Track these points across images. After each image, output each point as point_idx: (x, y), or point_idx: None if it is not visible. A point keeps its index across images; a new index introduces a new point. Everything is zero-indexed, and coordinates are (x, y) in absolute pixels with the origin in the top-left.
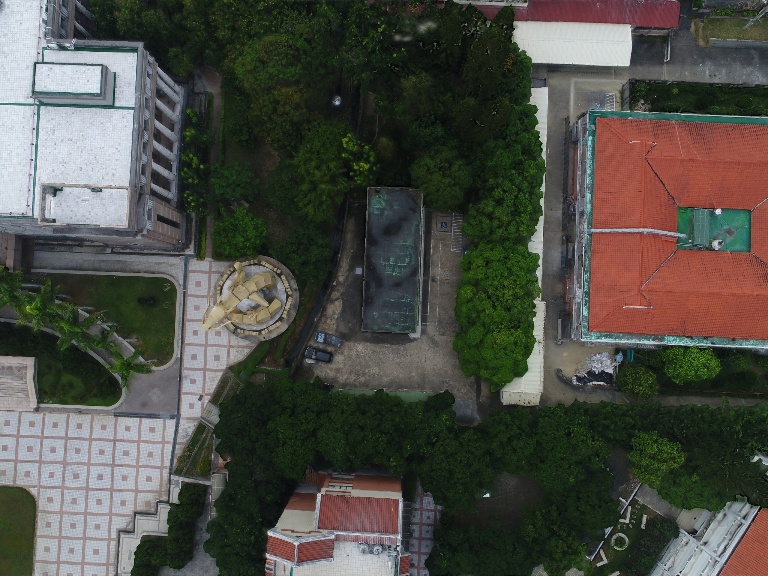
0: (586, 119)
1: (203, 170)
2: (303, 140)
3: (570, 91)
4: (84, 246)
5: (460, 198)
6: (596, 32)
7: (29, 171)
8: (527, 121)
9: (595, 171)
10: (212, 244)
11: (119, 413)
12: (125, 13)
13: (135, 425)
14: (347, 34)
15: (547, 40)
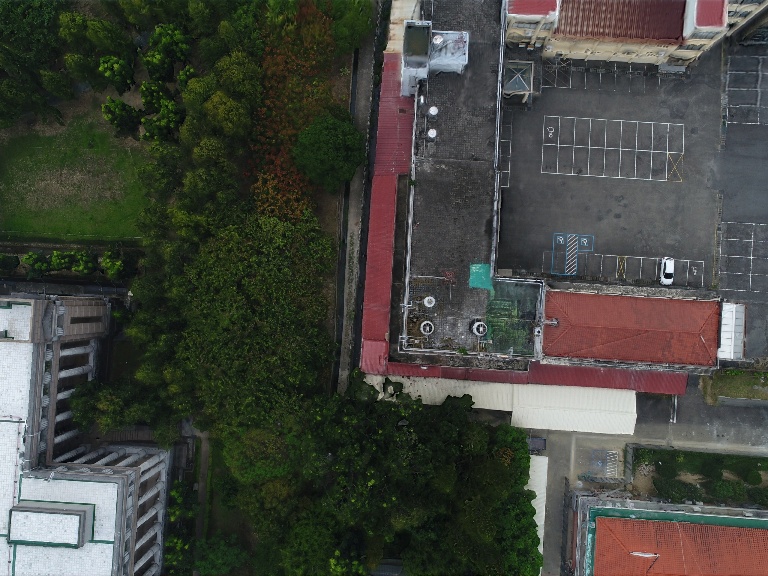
0: (586, 510)
1: None
2: (291, 530)
3: (571, 448)
4: None
5: None
6: (599, 399)
7: None
8: (524, 521)
9: (594, 574)
10: None
11: None
12: (107, 421)
13: None
14: (335, 484)
15: (548, 409)
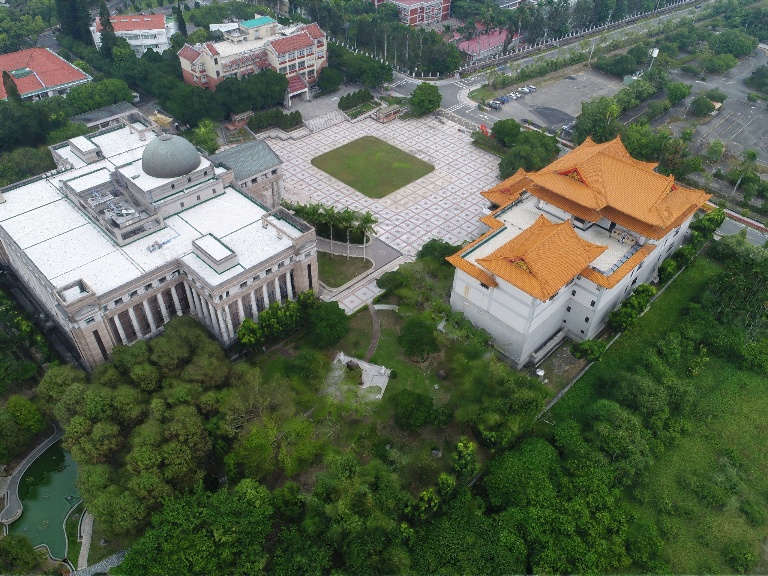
0: None
1: None
2: None
3: None
4: None
5: None
6: None
7: (141, 148)
8: None
9: None
10: None
11: None
12: None
13: None
14: (0, 110)
15: None
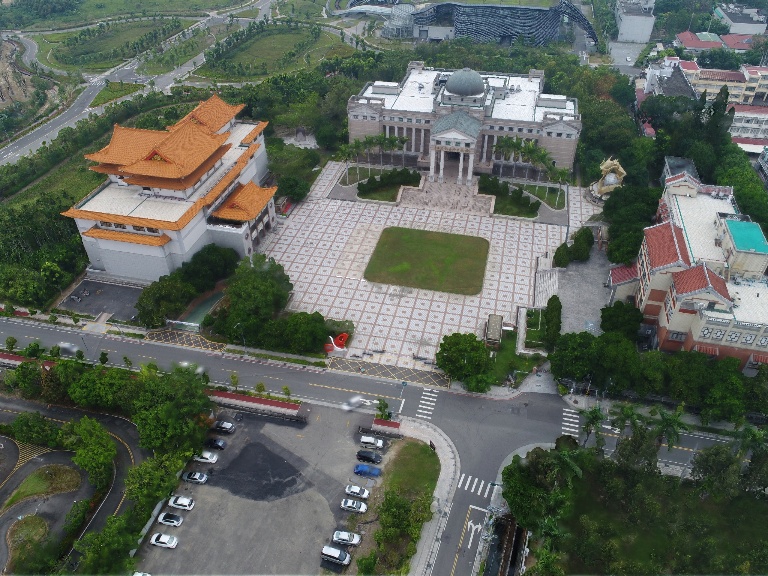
0: (762, 152)
1: (583, 152)
2: None
3: None
4: (516, 178)
5: (711, 162)
6: None
7: None
8: None
9: None
10: (580, 183)
11: (536, 222)
12: None
13: (545, 226)
14: None
15: None
